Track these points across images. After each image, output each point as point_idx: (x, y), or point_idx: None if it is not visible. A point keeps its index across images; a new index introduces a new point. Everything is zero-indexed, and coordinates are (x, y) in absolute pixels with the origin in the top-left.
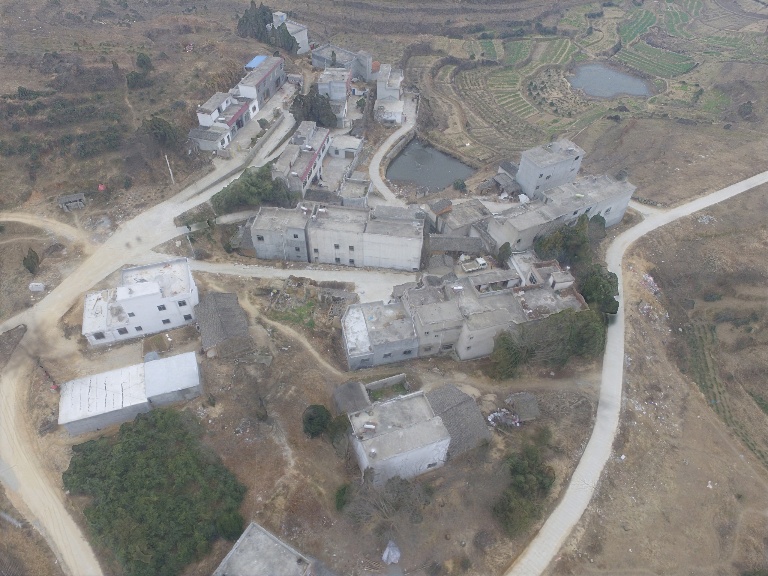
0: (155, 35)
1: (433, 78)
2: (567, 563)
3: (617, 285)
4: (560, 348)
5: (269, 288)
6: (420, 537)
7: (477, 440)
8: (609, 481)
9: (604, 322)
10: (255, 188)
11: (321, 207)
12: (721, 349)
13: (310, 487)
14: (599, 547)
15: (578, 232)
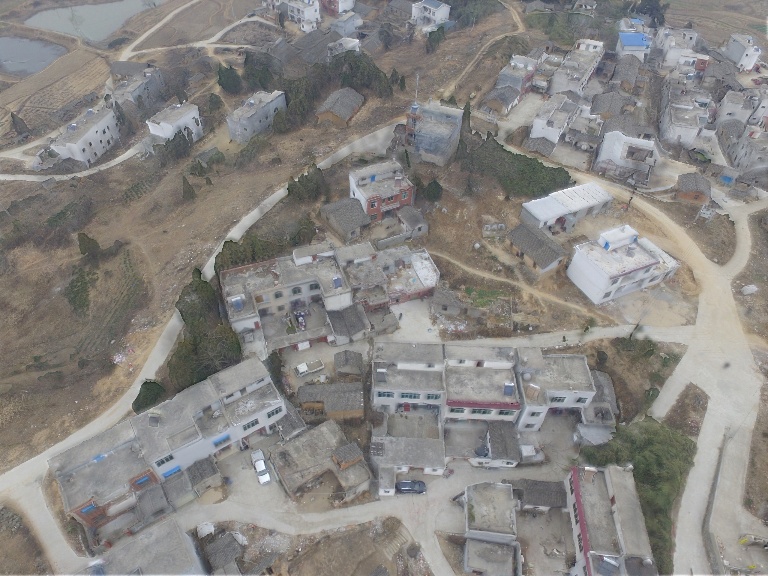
0: None
1: None
2: None
3: None
4: None
5: None
6: None
7: None
8: None
9: None
10: (636, 444)
11: None
12: None
13: (427, 183)
14: None
15: None
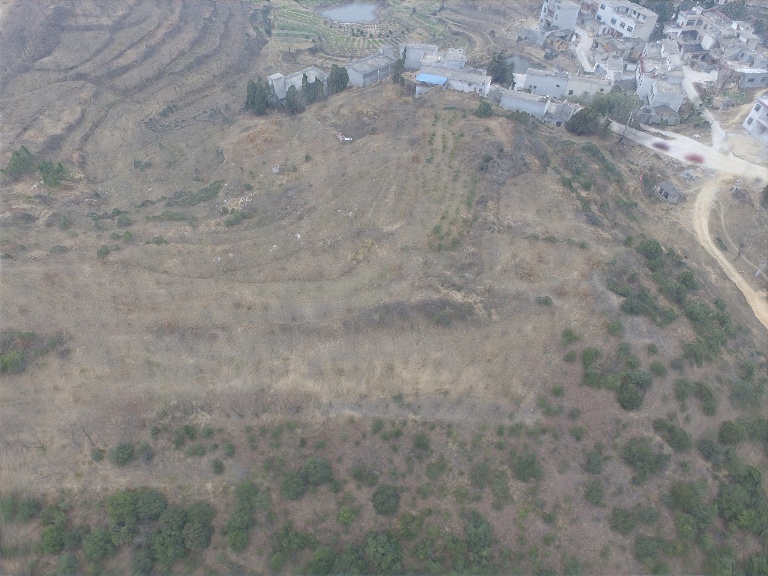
0: None
1: None
2: None
3: None
4: None
5: None
6: None
7: None
8: None
9: None
10: None
11: None
12: None
13: None
14: None
15: None
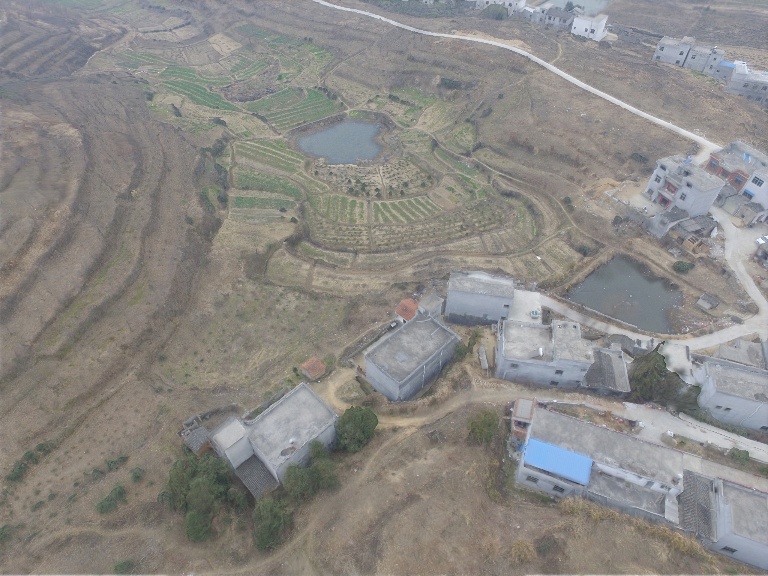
0: None
1: None
2: None
3: None
4: None
5: None
6: None
7: None
8: None
9: None
10: None
11: None
12: None
13: None
14: None
15: None
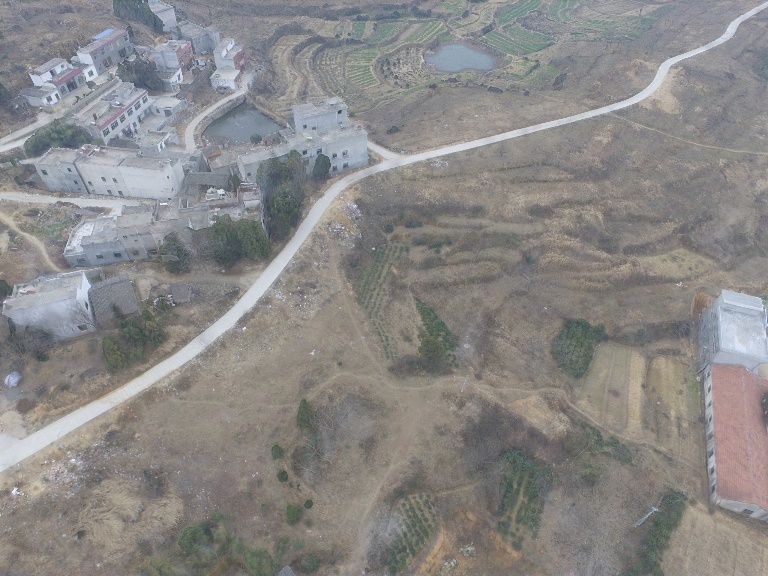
0: (33, 13)
1: (296, 54)
2: (154, 394)
3: (292, 203)
4: (222, 248)
5: (36, 210)
6: (41, 370)
7: (123, 310)
8: (221, 343)
9: (289, 236)
10: (58, 134)
11: (102, 148)
12: (410, 266)
13: None
14: (187, 385)
15: (280, 163)
